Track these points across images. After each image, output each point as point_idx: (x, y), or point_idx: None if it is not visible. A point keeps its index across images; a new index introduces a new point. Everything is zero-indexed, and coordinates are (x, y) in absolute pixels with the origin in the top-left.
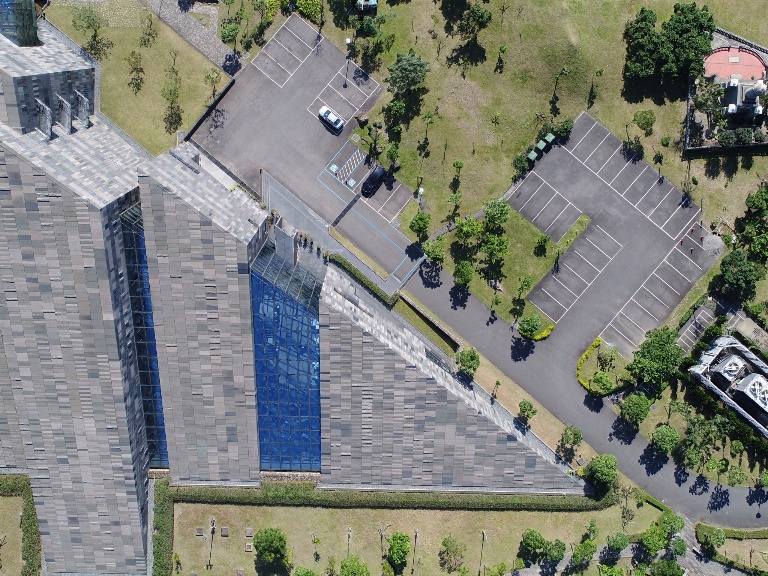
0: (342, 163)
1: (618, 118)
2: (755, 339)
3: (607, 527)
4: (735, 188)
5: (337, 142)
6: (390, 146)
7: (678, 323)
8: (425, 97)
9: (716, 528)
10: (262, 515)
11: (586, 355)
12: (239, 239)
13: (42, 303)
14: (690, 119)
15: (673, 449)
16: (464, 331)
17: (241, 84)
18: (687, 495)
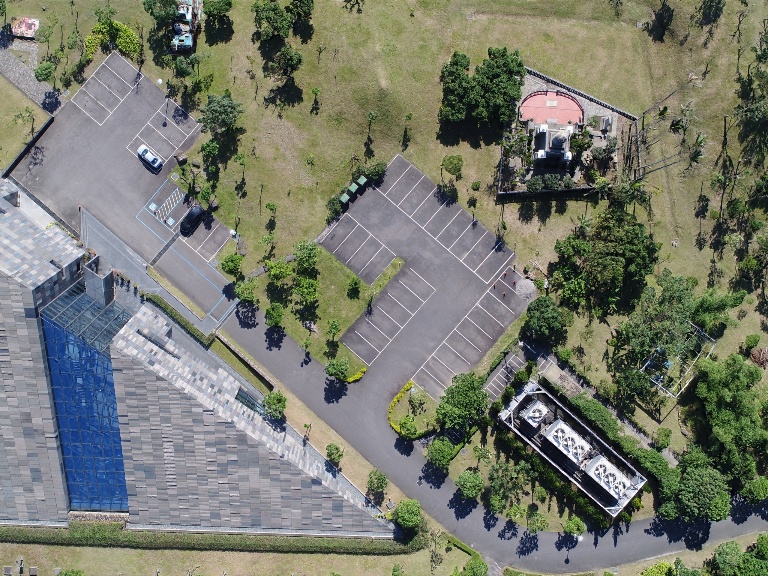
0: (161, 202)
1: (433, 161)
2: (561, 385)
3: (416, 571)
4: (548, 233)
5: (156, 181)
6: None
7: (489, 367)
8: (242, 137)
9: (519, 574)
10: (70, 555)
11: (397, 398)
12: (23, 284)
13: None
14: (503, 163)
15: (482, 493)
16: (279, 372)
17: (61, 122)
18: (496, 540)
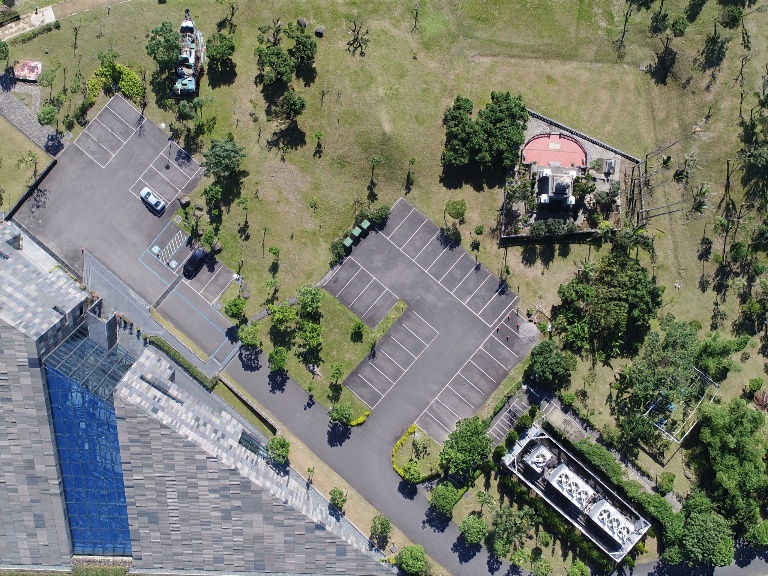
0: (164, 244)
1: (436, 204)
2: (565, 430)
3: None
4: (552, 276)
5: (159, 223)
6: (211, 228)
7: (493, 411)
8: (245, 180)
9: None
10: None
11: (401, 442)
12: (27, 334)
13: None
14: (506, 207)
15: (486, 537)
16: (282, 415)
17: (63, 164)
18: None
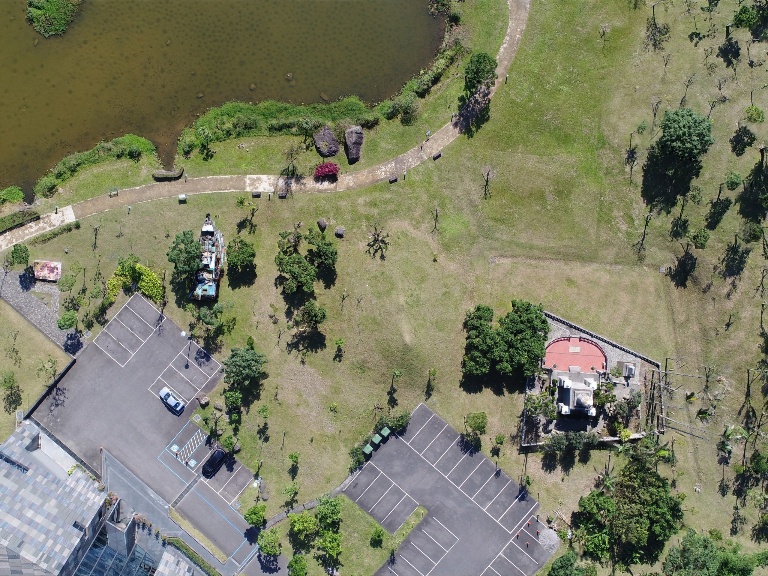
0: (183, 443)
1: (456, 409)
2: None
3: None
4: (572, 482)
5: (178, 422)
6: (231, 428)
7: None
8: (265, 382)
9: None
10: None
11: None
12: (48, 570)
13: None
14: (527, 414)
15: None
16: None
17: (82, 363)
18: None
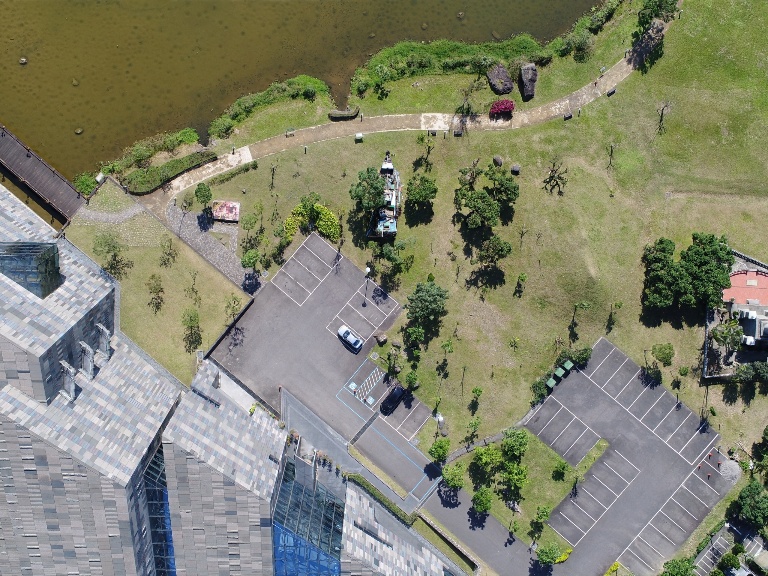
0: (361, 381)
1: (636, 343)
2: None
3: None
4: (752, 414)
5: (356, 360)
6: (409, 365)
7: (695, 549)
8: (444, 319)
9: None
10: None
11: None
12: (262, 497)
13: (66, 566)
14: (708, 346)
15: None
16: (482, 552)
17: (260, 302)
18: None
